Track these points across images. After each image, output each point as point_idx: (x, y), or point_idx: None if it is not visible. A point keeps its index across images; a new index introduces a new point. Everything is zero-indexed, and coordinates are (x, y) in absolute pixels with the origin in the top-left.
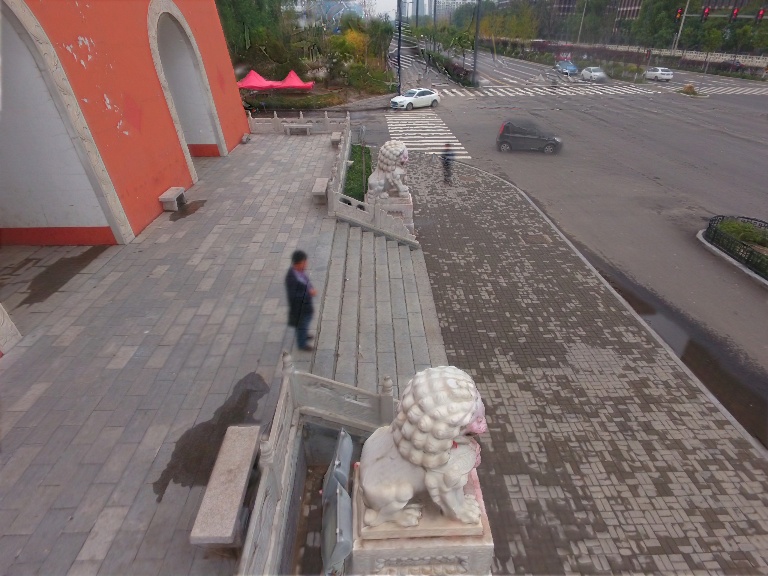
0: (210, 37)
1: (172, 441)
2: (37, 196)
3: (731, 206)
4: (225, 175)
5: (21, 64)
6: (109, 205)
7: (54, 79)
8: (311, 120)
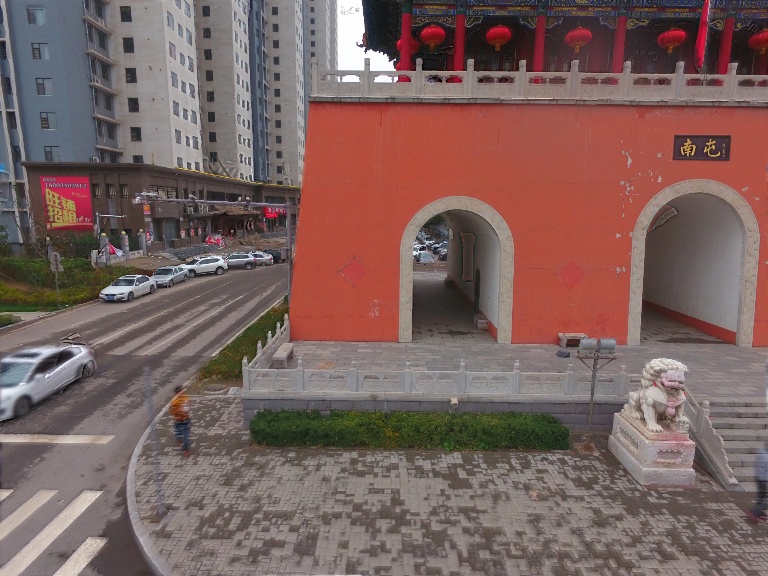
0: None
1: None
2: (713, 305)
3: None
4: None
5: (737, 240)
6: (742, 320)
7: (748, 249)
8: None
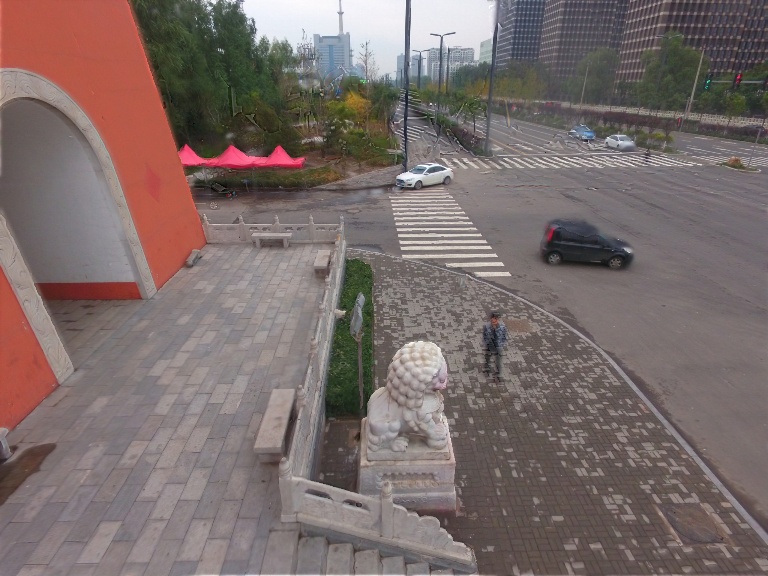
0: (137, 124)
1: None
2: None
3: None
4: (127, 353)
5: None
6: None
7: None
8: (290, 226)
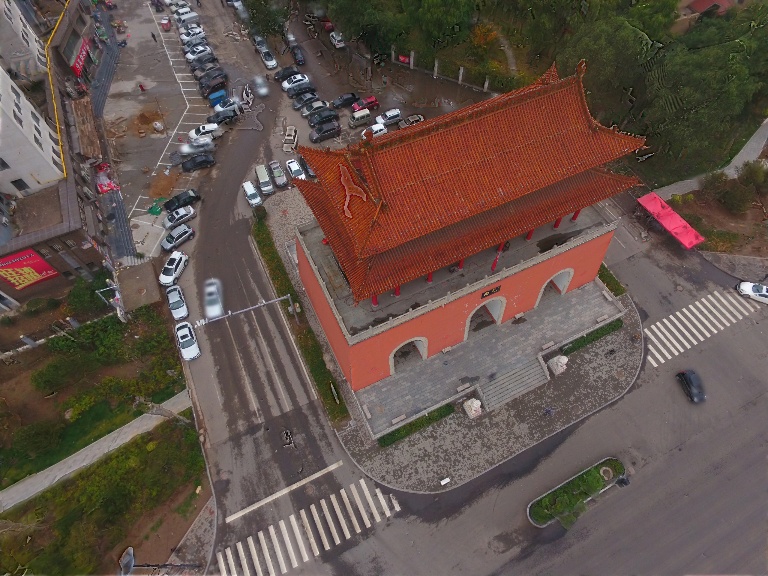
0: None
1: (465, 376)
2: None
3: (658, 475)
4: (546, 310)
5: None
6: (498, 320)
7: None
8: (615, 298)
